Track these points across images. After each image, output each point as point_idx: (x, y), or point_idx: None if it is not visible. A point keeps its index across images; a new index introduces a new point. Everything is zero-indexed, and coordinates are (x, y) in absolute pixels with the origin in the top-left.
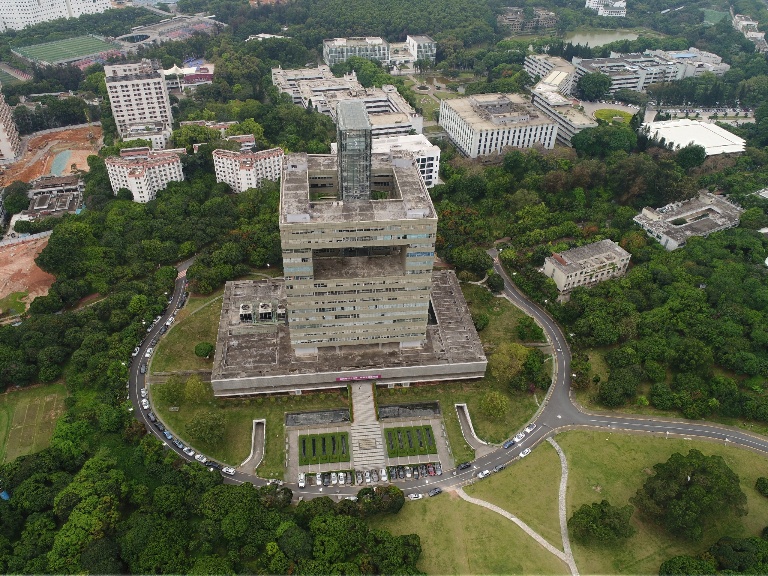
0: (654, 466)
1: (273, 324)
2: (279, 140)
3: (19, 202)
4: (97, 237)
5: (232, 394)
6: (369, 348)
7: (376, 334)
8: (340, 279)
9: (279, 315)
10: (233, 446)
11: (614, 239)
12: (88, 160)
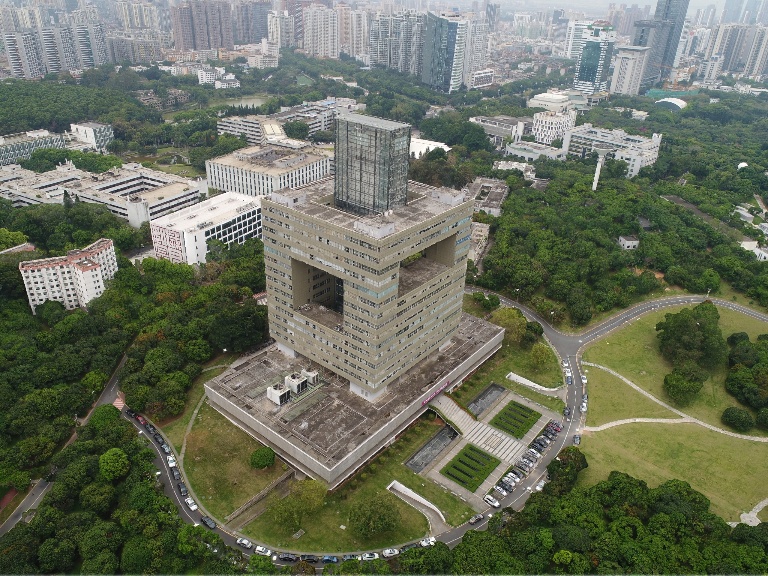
0: (659, 337)
1: (314, 391)
2: (55, 244)
3: None
4: None
5: (345, 477)
6: (419, 364)
7: (431, 342)
8: (414, 290)
9: (313, 379)
10: (401, 521)
11: None
12: None
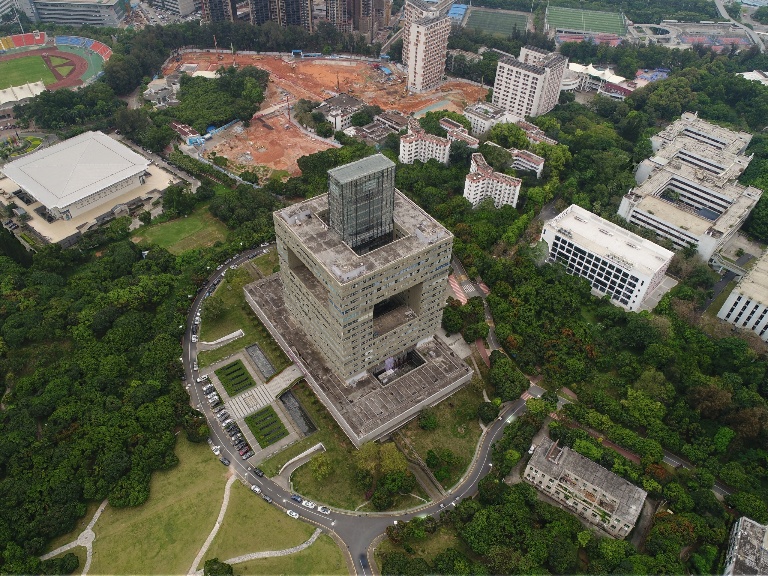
0: None
1: None
2: (569, 177)
3: (359, 120)
4: None
5: (251, 306)
6: None
7: None
8: (301, 281)
9: None
10: (215, 330)
11: (672, 505)
12: (426, 114)
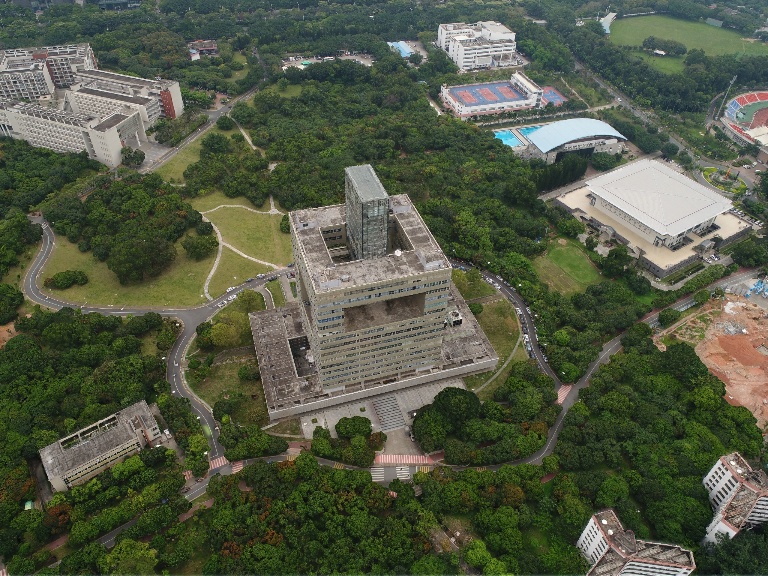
0: None
1: None
2: None
3: None
4: (692, 410)
5: None
6: None
7: None
8: None
9: None
10: None
11: None
12: None
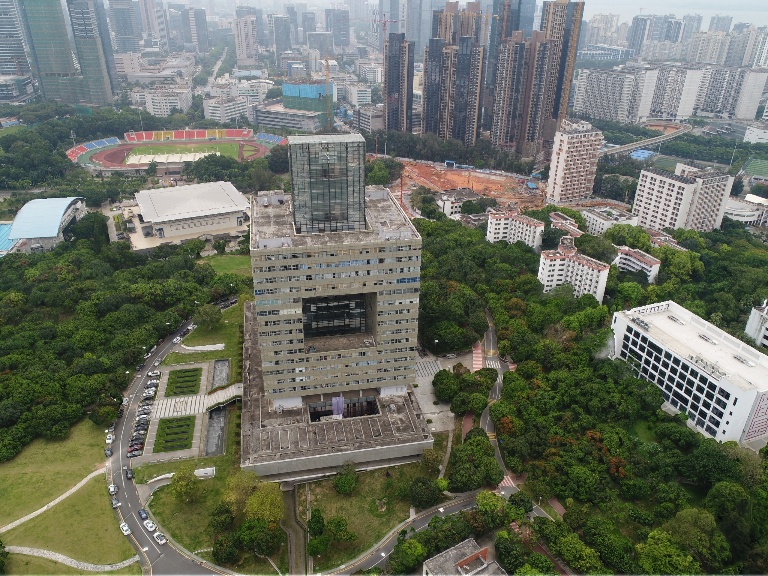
0: None
1: None
2: None
3: (467, 207)
4: None
5: None
6: None
7: None
8: None
9: None
10: (201, 339)
11: None
12: None
